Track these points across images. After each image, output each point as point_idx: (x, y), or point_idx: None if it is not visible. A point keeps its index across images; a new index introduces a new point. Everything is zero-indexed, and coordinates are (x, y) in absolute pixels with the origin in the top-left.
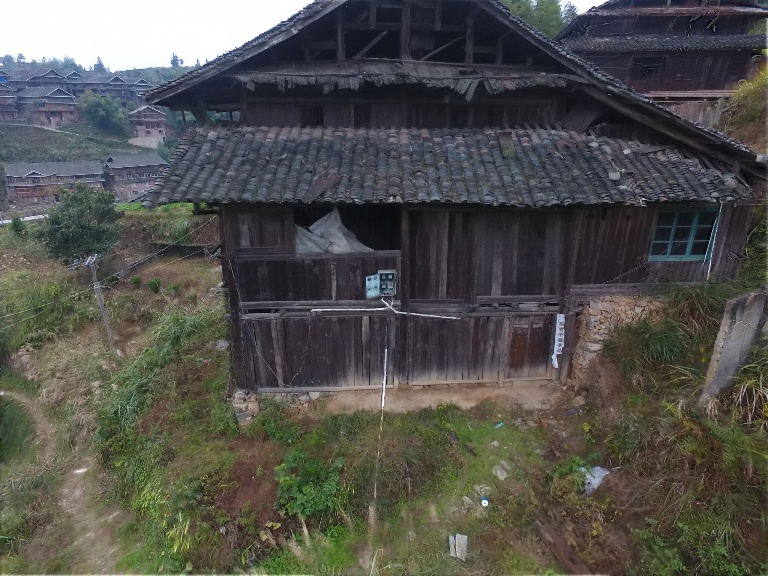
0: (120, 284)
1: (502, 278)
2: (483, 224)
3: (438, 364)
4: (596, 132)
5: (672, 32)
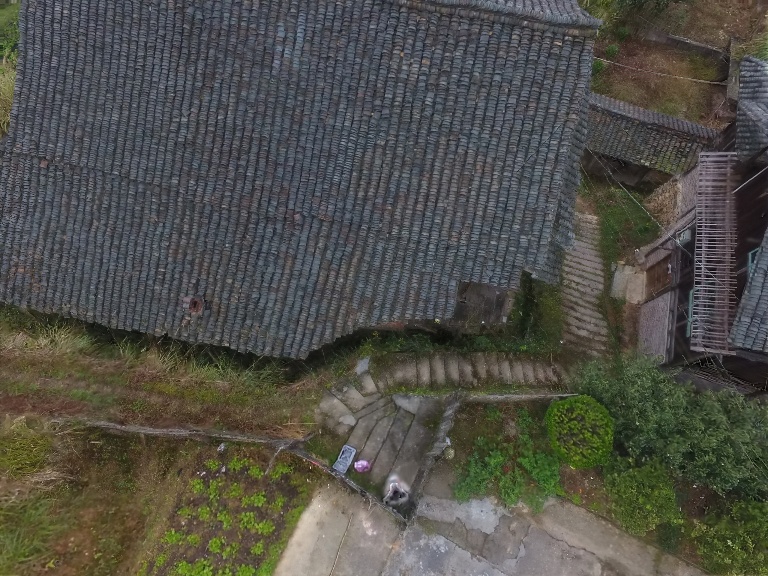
0: (627, 43)
1: None
2: None
3: None
4: None
5: None
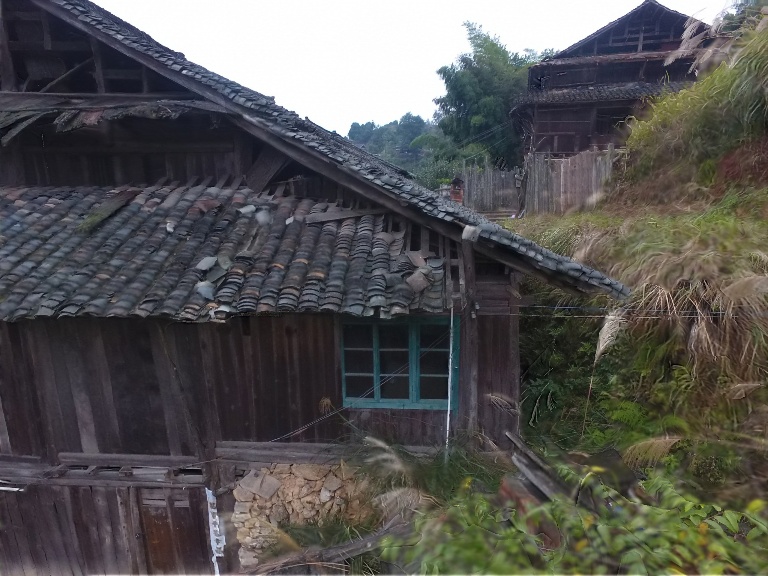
0: None
1: (95, 425)
2: (43, 337)
3: (31, 555)
4: (289, 190)
5: (643, 79)
